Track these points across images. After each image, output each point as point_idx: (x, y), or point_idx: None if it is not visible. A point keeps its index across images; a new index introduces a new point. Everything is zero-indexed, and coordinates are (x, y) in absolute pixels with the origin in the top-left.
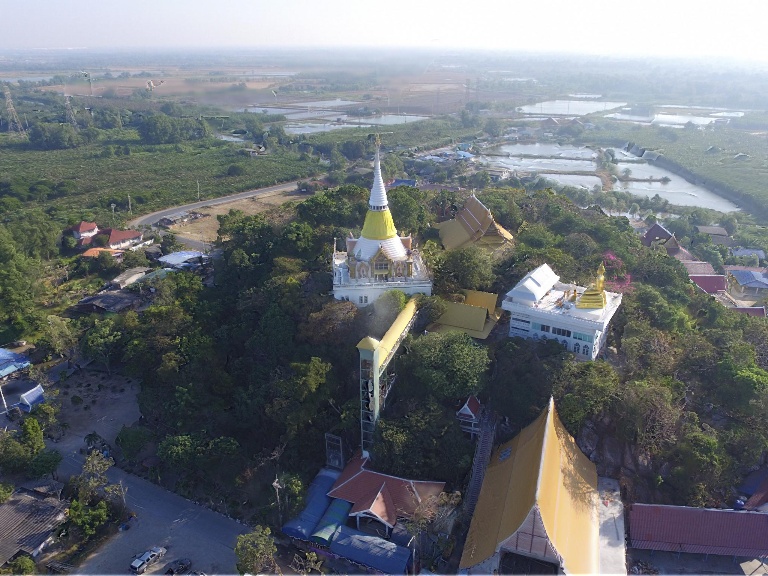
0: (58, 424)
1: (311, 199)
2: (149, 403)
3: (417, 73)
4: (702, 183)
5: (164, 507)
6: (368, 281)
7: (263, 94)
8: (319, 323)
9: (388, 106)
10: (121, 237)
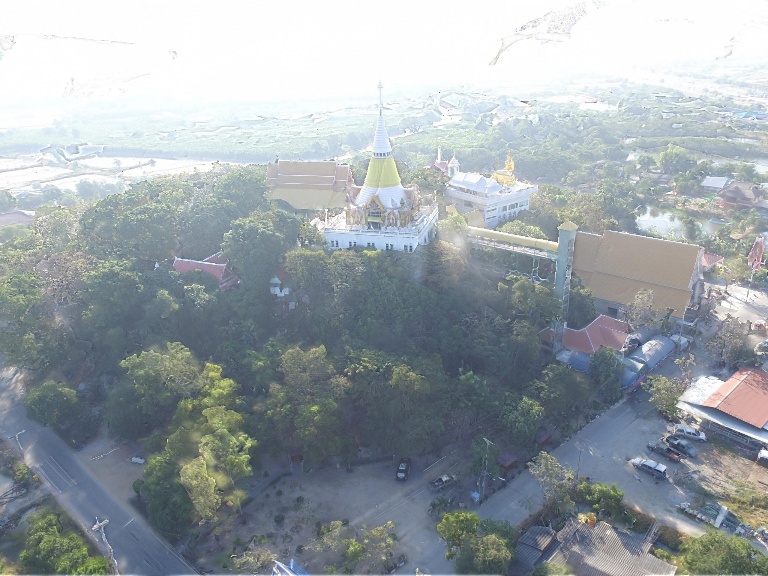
0: (393, 541)
1: (137, 212)
2: (439, 424)
3: None
4: (184, 157)
5: (570, 461)
6: (411, 225)
7: (157, 57)
8: (454, 263)
9: None
10: None
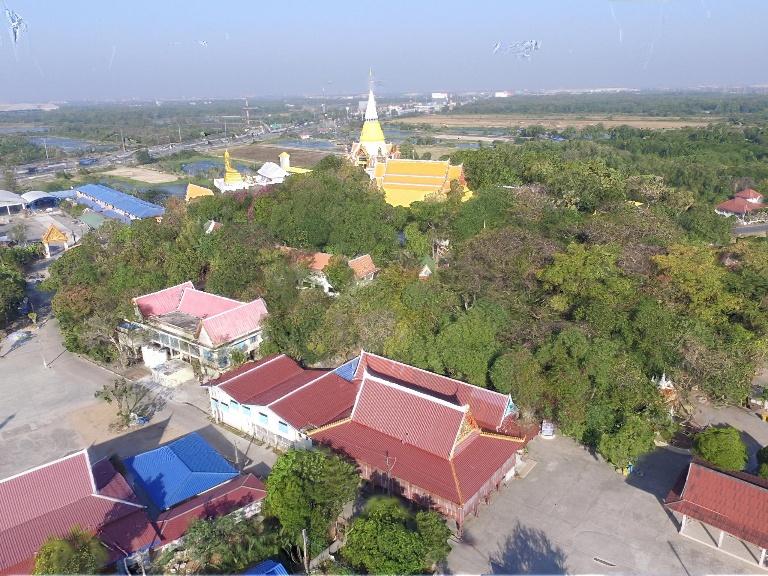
0: None
1: None
2: None
3: (623, 15)
4: None
5: None
6: None
7: None
8: None
9: (640, 65)
10: (728, 206)
